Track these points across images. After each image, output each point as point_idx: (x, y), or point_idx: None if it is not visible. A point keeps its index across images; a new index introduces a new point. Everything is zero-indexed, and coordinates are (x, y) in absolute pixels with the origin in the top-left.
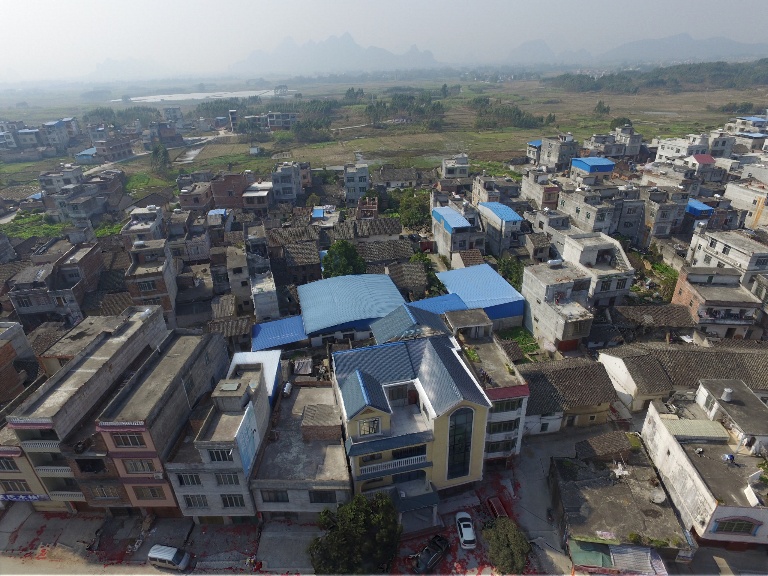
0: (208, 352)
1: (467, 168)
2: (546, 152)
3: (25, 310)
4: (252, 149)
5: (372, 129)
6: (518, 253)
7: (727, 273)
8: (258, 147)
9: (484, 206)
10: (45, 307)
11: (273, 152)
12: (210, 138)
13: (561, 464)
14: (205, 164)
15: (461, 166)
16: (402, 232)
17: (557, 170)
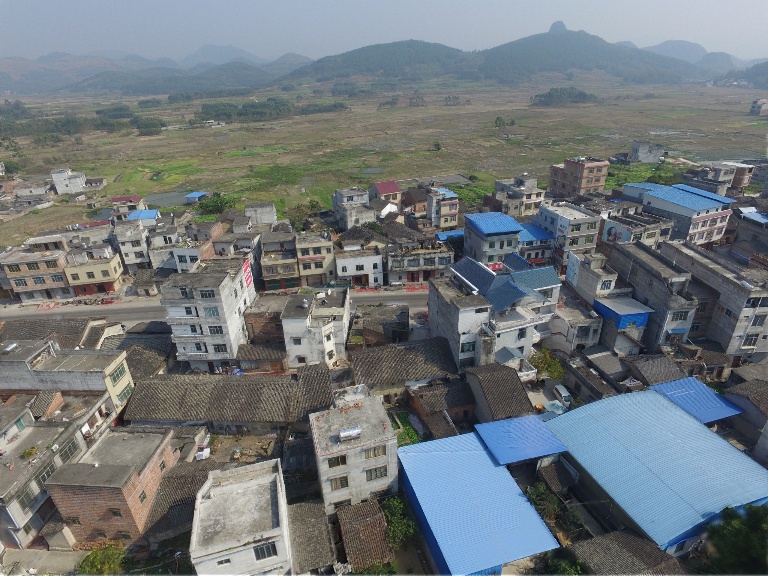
0: None
1: None
2: None
3: None
4: None
5: None
6: None
7: (80, 466)
8: None
9: None
10: None
11: None
12: None
13: (404, 327)
14: None
15: None
16: None
17: None
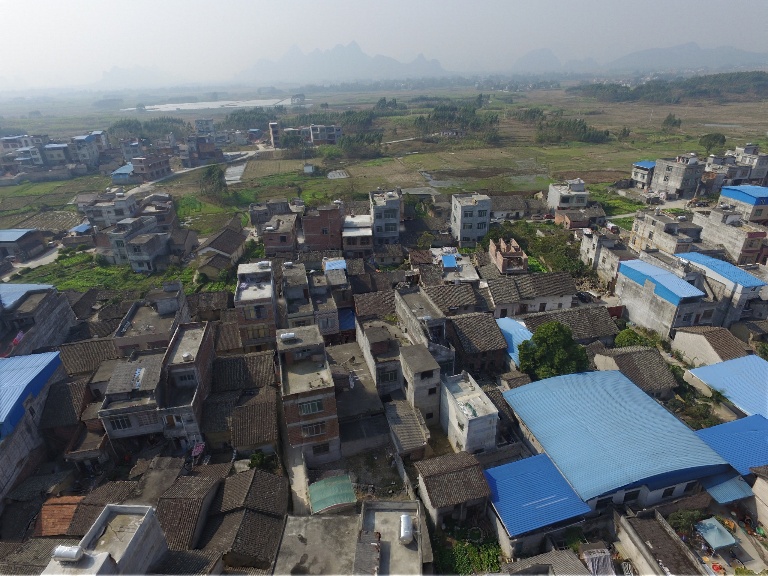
0: None
1: (586, 196)
2: (662, 175)
3: (120, 433)
4: (307, 167)
5: (422, 143)
6: (763, 330)
7: None
8: (313, 165)
9: (690, 260)
10: (149, 428)
11: (327, 170)
12: (251, 153)
13: None
14: (257, 185)
15: (579, 194)
16: None
17: (678, 197)
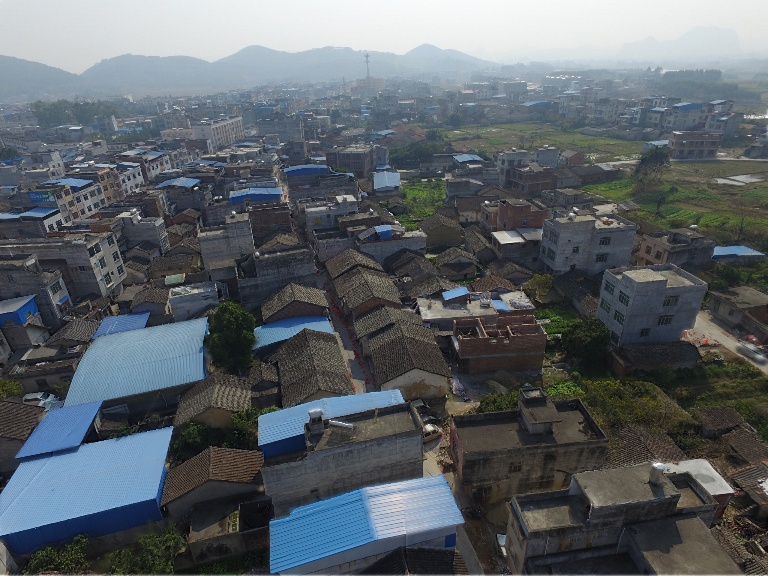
0: (13, 276)
1: None
2: None
3: None
4: None
5: None
6: None
7: None
8: None
9: None
10: None
11: None
12: None
13: None
14: (735, 192)
15: None
16: (458, 404)
17: None
